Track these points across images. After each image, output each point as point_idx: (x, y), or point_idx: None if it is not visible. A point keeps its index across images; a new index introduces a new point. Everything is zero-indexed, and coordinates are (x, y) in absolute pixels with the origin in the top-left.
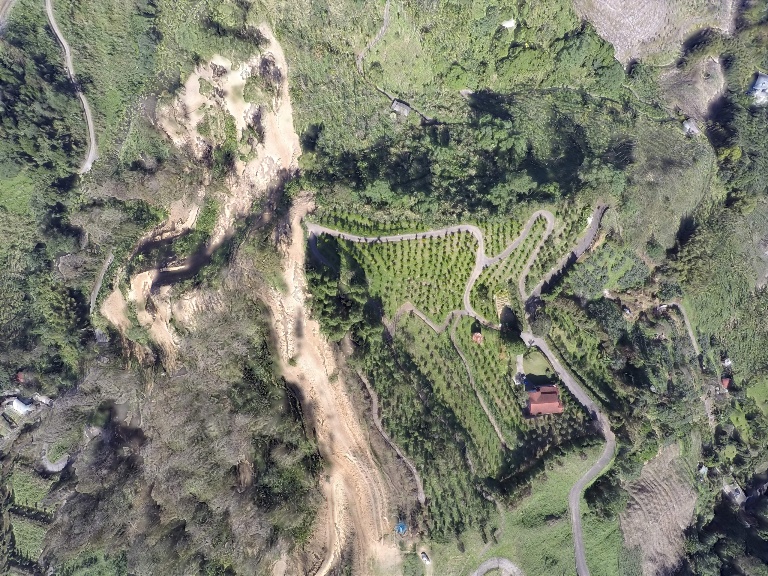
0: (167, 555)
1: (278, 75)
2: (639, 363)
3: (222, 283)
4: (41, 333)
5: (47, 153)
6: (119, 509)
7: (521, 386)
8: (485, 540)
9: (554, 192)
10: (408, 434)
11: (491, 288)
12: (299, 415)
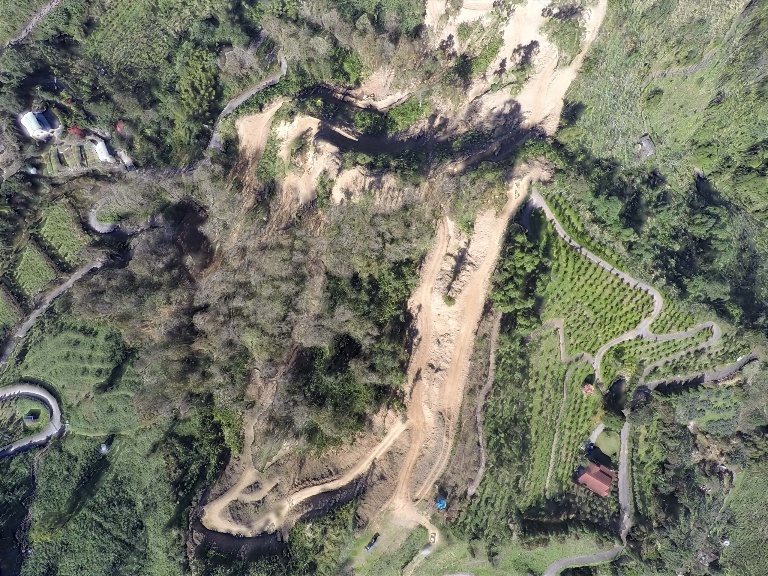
0: (181, 376)
1: (580, 36)
2: (684, 500)
3: (417, 184)
4: (163, 100)
5: None
6: (158, 307)
7: (583, 452)
8: (491, 559)
9: (736, 316)
10: (497, 430)
11: (626, 356)
12: (411, 347)
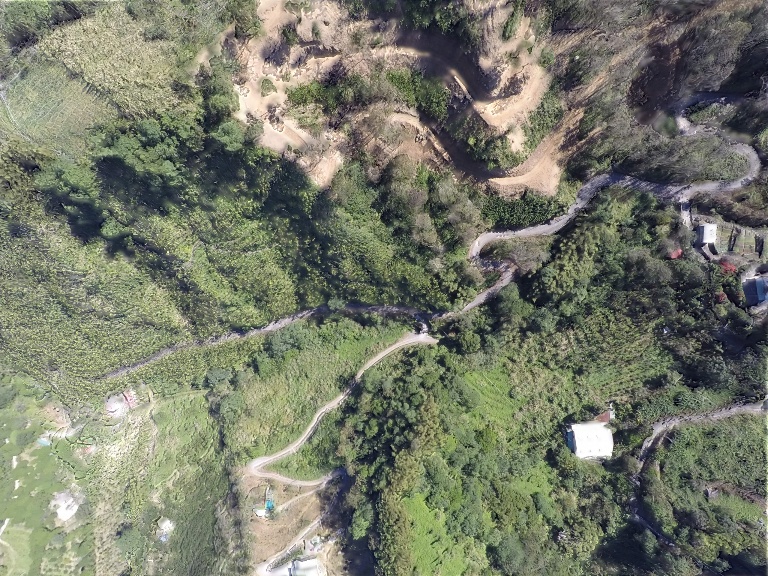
0: None
1: (228, 48)
2: None
3: None
4: None
5: (430, 367)
6: None
7: None
8: None
9: None
10: None
11: None
12: None
